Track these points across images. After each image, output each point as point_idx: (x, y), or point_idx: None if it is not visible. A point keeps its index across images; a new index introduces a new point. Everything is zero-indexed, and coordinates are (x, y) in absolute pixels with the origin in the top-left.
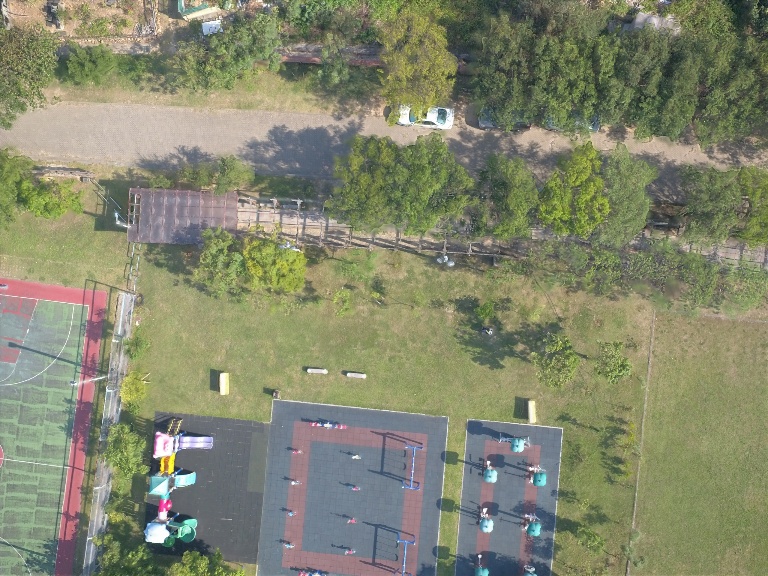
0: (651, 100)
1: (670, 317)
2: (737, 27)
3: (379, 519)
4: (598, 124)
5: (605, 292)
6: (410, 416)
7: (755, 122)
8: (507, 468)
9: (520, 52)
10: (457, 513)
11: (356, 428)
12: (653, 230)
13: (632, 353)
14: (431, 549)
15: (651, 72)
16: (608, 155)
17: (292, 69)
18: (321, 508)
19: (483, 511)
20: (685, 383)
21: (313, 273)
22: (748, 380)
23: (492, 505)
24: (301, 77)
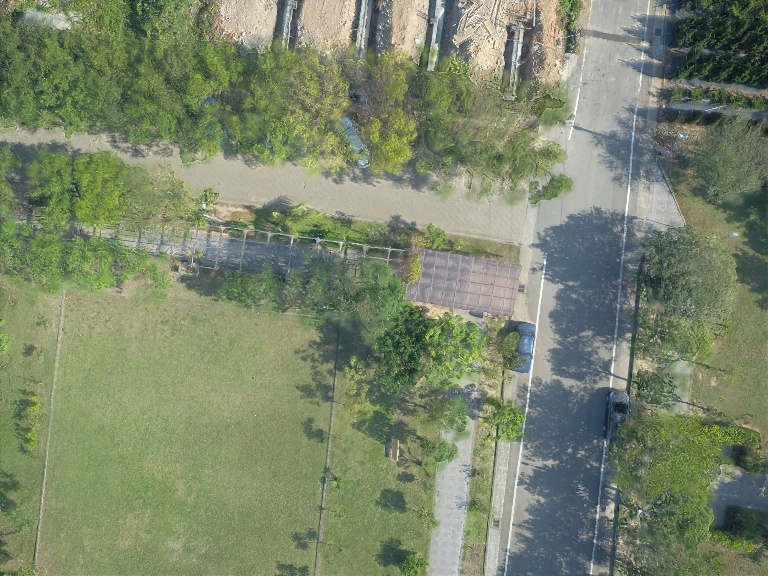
0: None
1: (79, 296)
2: (133, 24)
3: None
4: None
5: None
6: None
7: (93, 112)
8: None
9: None
10: None
11: None
12: None
13: (43, 330)
14: None
15: None
16: None
17: None
18: None
19: None
20: (92, 358)
21: None
22: (149, 355)
23: None
24: None
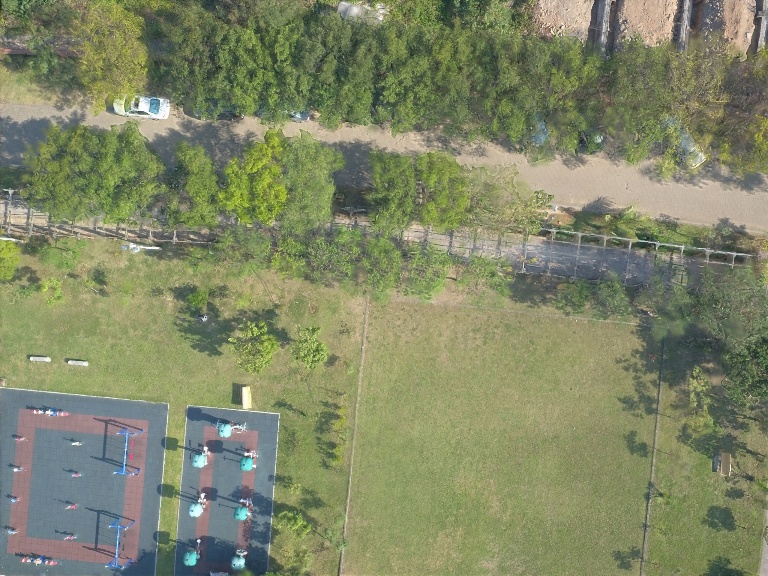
0: (328, 87)
1: (384, 303)
2: (445, 16)
3: (101, 505)
4: (307, 113)
5: (320, 279)
6: (131, 403)
7: (434, 109)
8: (225, 454)
9: (204, 41)
10: (177, 498)
11: (79, 415)
12: (362, 217)
13: (346, 339)
14: (152, 534)
15: (324, 60)
16: (289, 142)
17: (17, 61)
18: (45, 494)
19: (201, 496)
20: (398, 368)
21: (37, 262)
22: (459, 365)
23: (211, 490)
24: (25, 69)
